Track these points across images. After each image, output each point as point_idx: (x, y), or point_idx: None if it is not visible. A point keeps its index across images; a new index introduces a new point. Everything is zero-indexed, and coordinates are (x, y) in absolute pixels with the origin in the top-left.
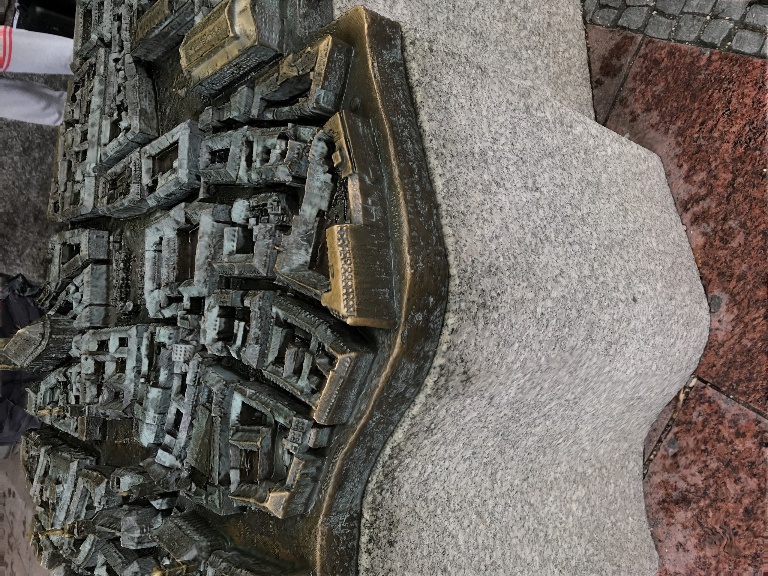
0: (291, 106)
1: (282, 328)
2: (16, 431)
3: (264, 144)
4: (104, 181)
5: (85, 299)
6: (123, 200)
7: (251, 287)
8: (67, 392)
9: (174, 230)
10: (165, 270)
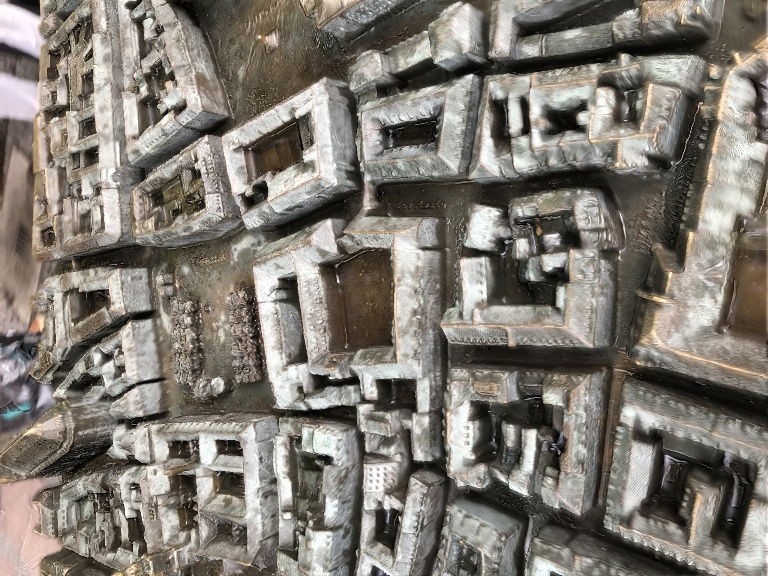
0: (588, 26)
1: (651, 445)
2: (17, 552)
3: (545, 101)
4: (140, 194)
5: (130, 376)
6: (191, 222)
7: (510, 358)
8: (110, 510)
9: (314, 266)
10: (310, 334)
